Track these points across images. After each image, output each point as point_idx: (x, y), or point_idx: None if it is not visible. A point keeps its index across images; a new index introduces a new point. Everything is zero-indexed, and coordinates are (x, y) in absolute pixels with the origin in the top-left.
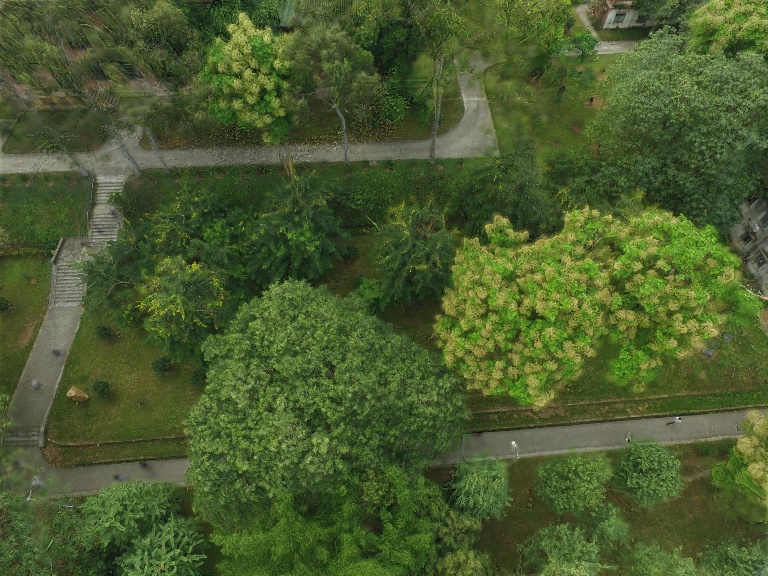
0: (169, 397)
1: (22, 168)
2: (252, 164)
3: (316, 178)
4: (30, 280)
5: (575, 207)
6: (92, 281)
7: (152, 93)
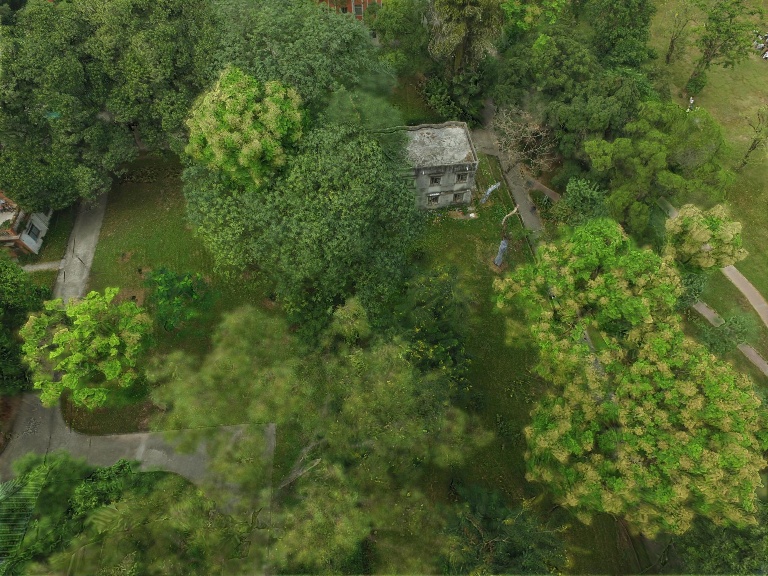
0: None
1: None
2: None
3: None
4: None
5: (421, 343)
6: None
7: None
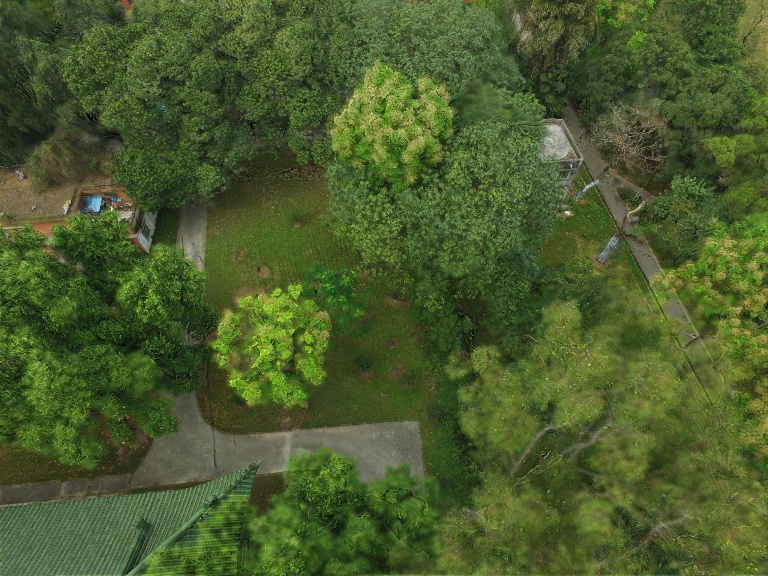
0: None
1: None
2: None
3: None
4: None
5: None
6: None
7: None
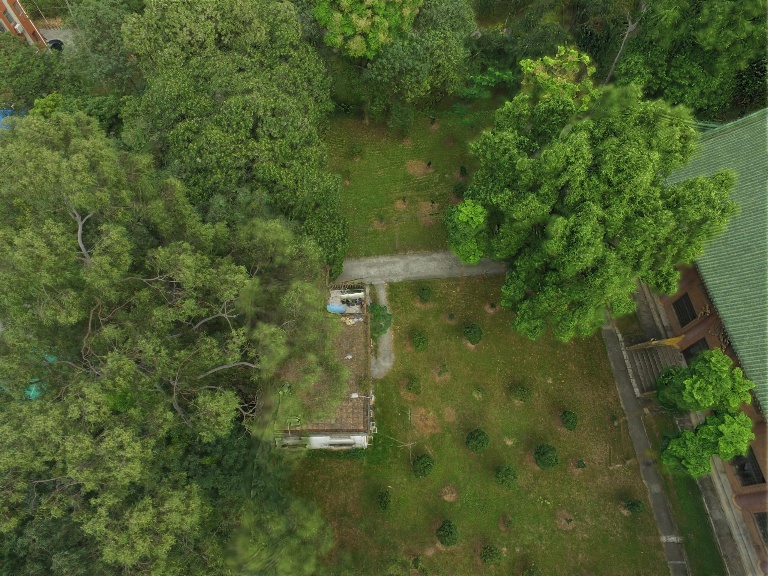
0: None
1: None
2: None
3: None
4: None
5: None
6: None
7: None
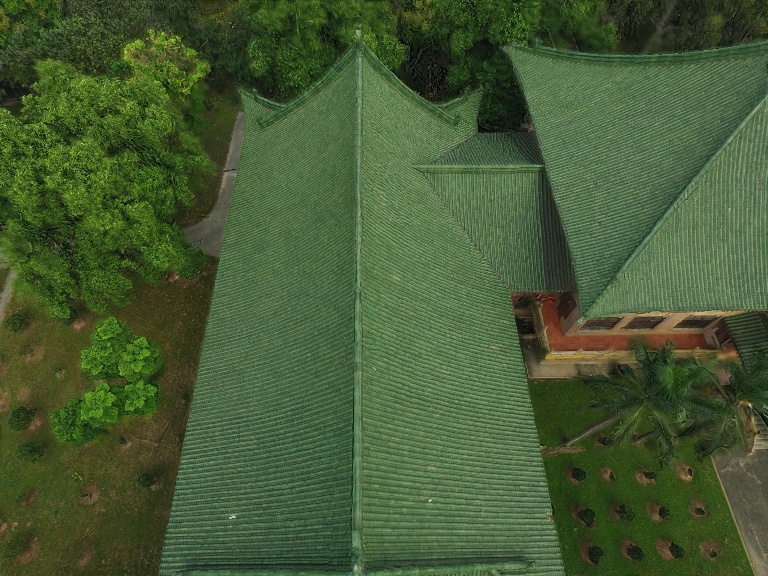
0: None
1: None
2: None
3: None
4: None
5: None
6: None
7: None
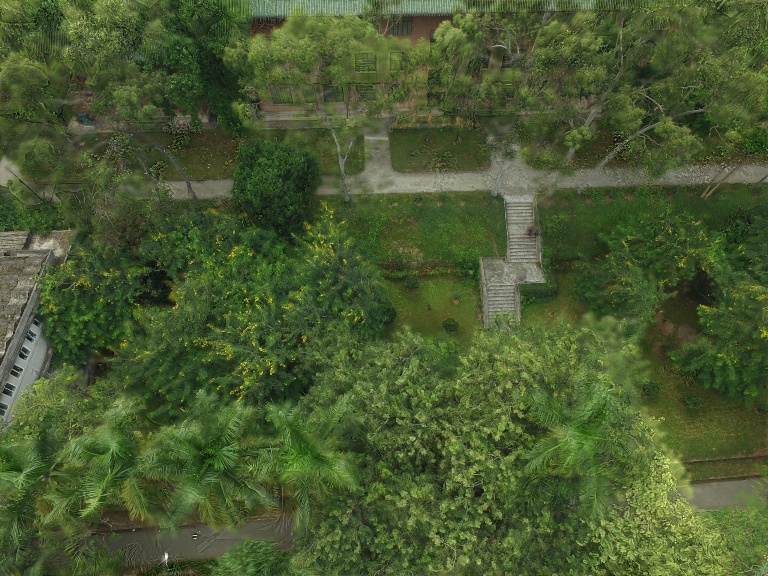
0: (658, 421)
1: (424, 187)
2: (654, 185)
3: (727, 200)
4: (452, 300)
5: None
6: (521, 302)
7: (511, 112)
